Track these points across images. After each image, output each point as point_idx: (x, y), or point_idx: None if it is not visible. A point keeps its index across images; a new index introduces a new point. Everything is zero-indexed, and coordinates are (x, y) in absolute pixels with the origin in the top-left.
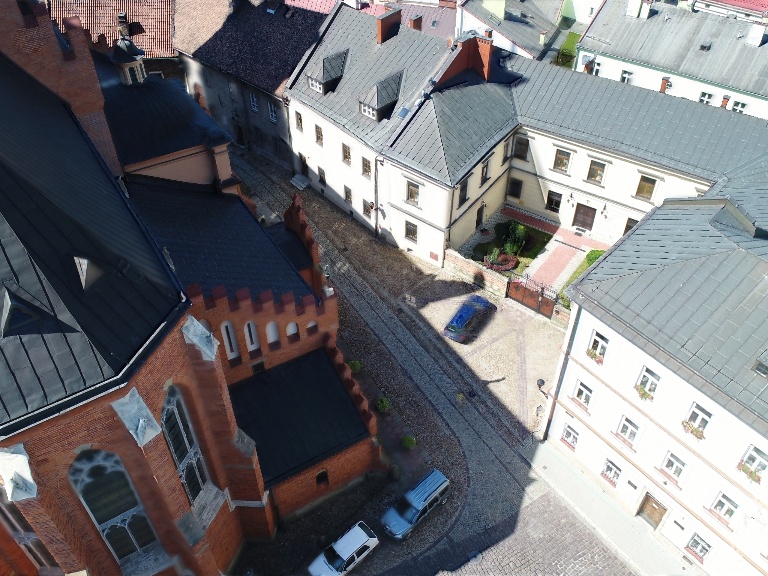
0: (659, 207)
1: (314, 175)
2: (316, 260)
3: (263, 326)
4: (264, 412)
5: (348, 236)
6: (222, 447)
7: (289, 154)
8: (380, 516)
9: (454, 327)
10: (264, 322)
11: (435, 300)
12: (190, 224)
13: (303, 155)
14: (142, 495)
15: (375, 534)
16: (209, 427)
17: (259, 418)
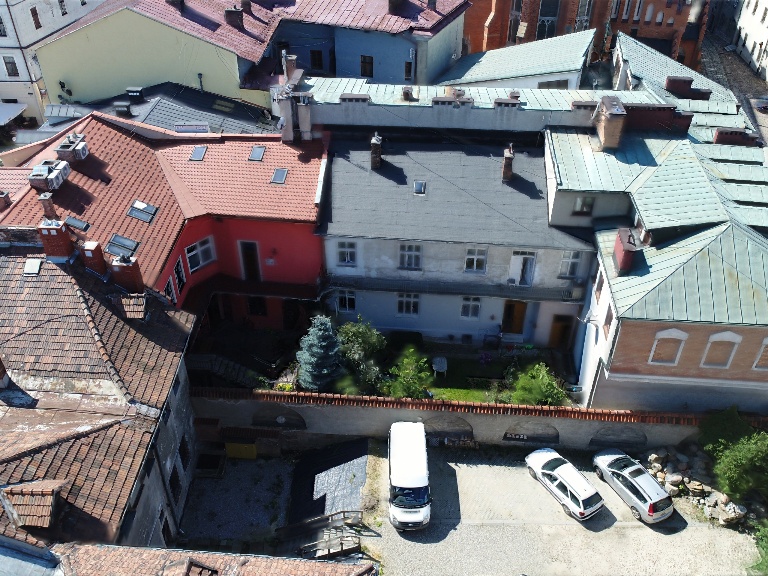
0: None
1: (741, 41)
2: (701, 39)
3: (647, 4)
4: None
5: (738, 70)
6: (598, 26)
7: (734, 31)
8: None
9: (765, 108)
10: (648, 2)
11: (765, 99)
12: None
13: (741, 27)
14: (561, 6)
15: None
16: (599, 8)
17: None
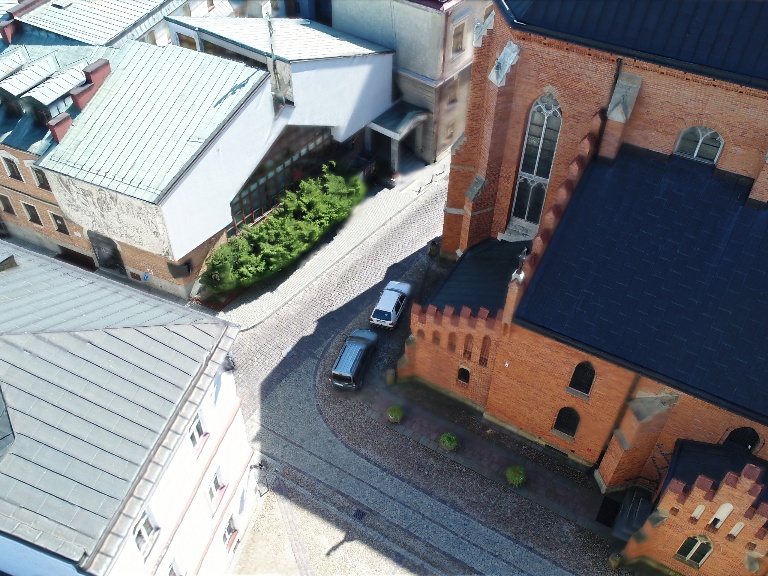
0: (96, 550)
1: None
2: None
3: None
4: (510, 271)
5: None
6: None
7: None
8: (383, 347)
9: None
10: None
11: None
12: (761, 292)
13: None
14: None
15: (379, 334)
16: None
17: (509, 267)
